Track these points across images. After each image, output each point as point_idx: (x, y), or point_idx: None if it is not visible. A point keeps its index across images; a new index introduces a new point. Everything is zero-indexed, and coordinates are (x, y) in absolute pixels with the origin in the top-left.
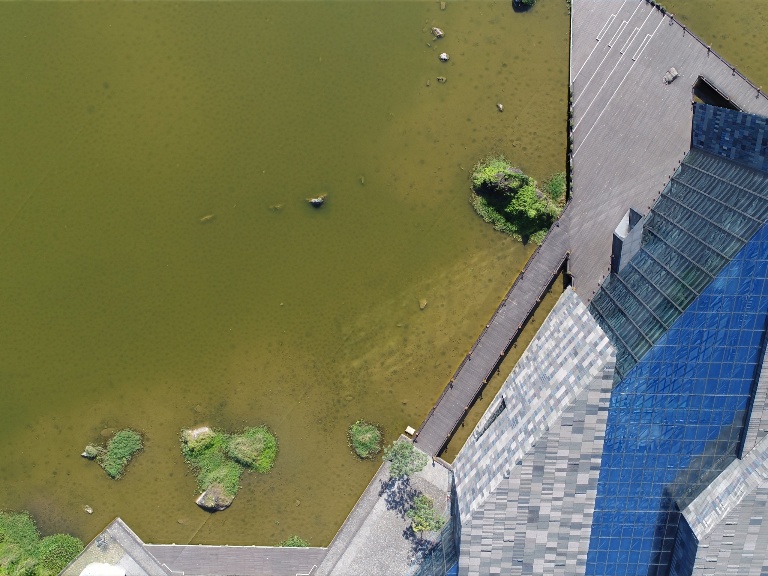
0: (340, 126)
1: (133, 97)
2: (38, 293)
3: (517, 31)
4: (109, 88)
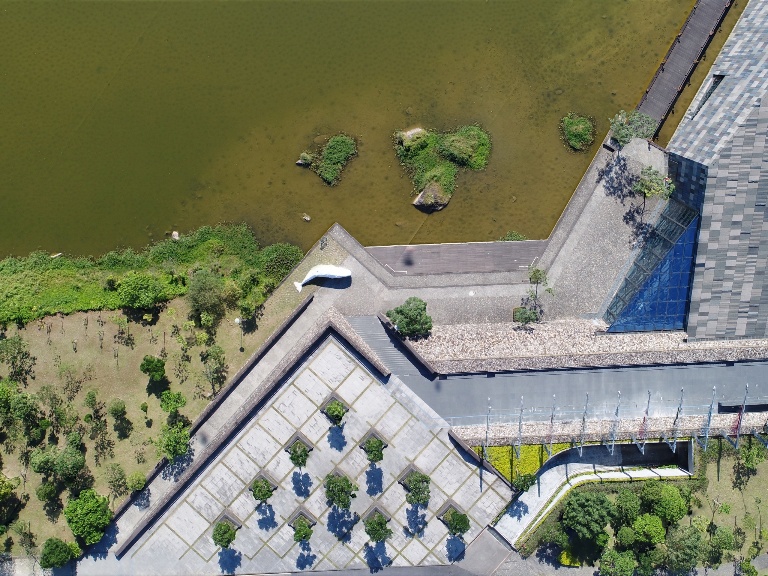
0: None
1: None
2: (242, 4)
3: None
4: None
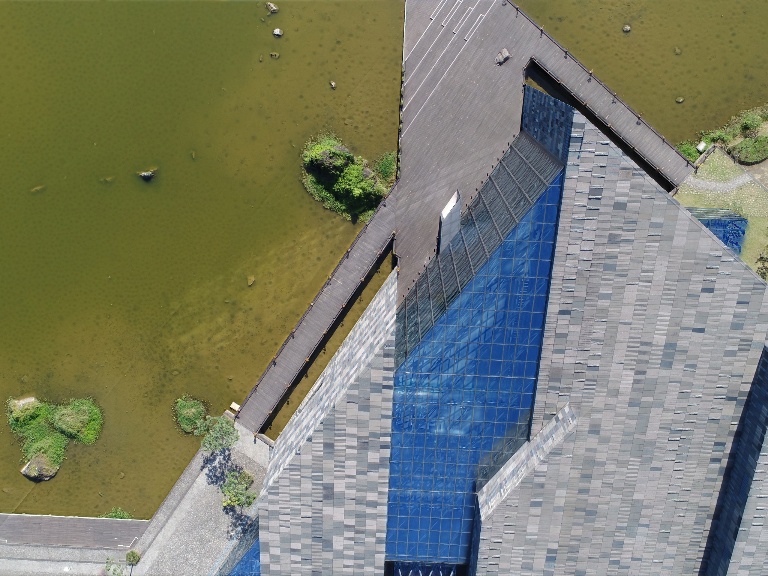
0: (172, 100)
1: None
2: None
3: (352, 8)
4: None
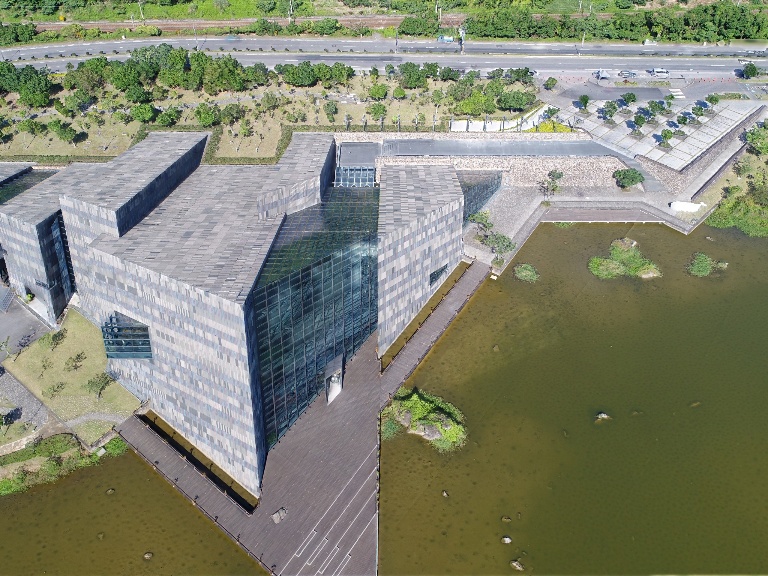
0: (598, 478)
1: None
2: None
3: (434, 568)
4: None
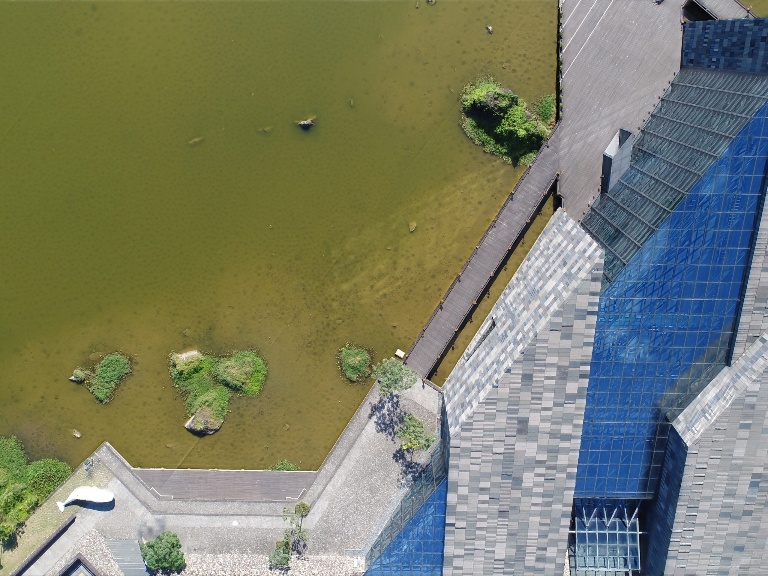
0: (329, 48)
1: (121, 19)
2: (26, 216)
3: None
4: (97, 10)
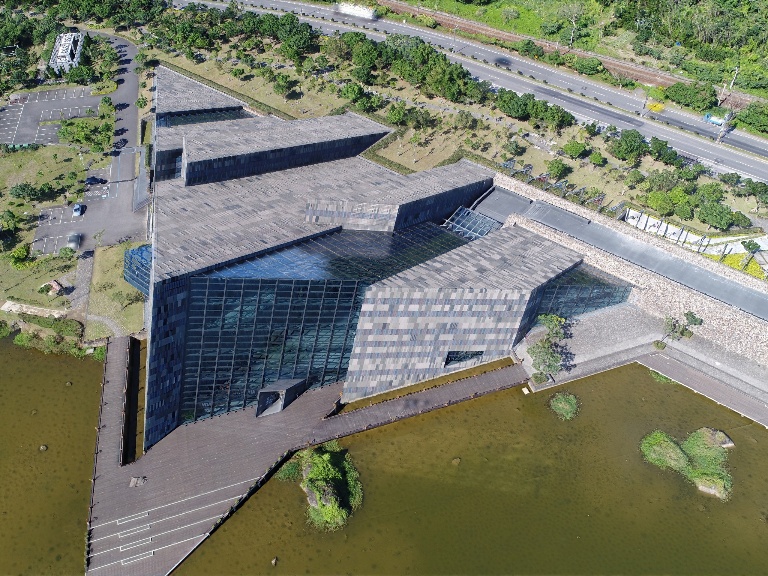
0: None
1: None
2: None
3: None
4: None
